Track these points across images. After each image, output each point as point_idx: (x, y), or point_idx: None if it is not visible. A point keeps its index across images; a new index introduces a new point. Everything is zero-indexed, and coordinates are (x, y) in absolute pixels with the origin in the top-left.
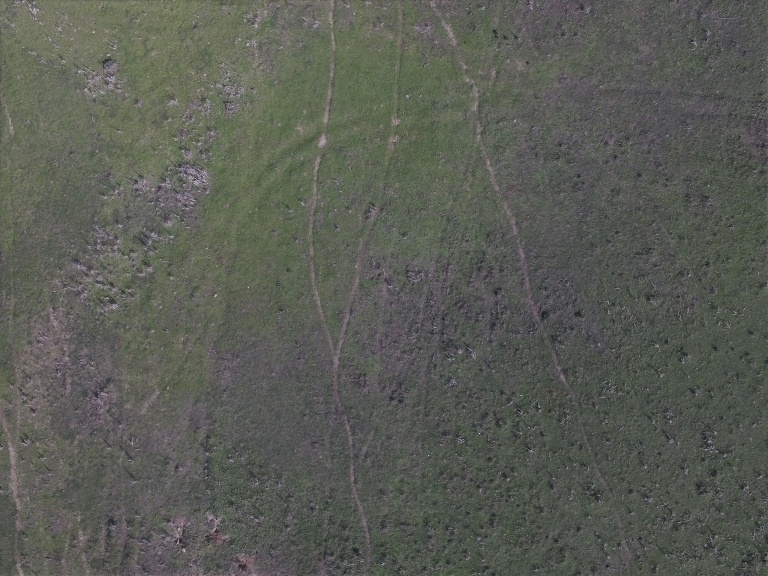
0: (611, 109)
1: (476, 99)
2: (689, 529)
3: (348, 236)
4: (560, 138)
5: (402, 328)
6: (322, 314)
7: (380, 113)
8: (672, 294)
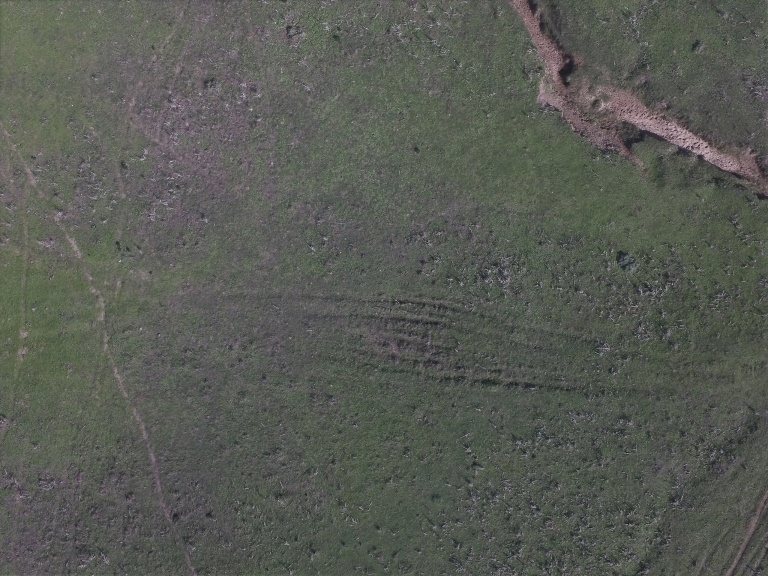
0: (235, 314)
1: (102, 309)
2: None
3: None
4: (186, 344)
5: (36, 536)
6: None
7: (8, 326)
8: (300, 492)
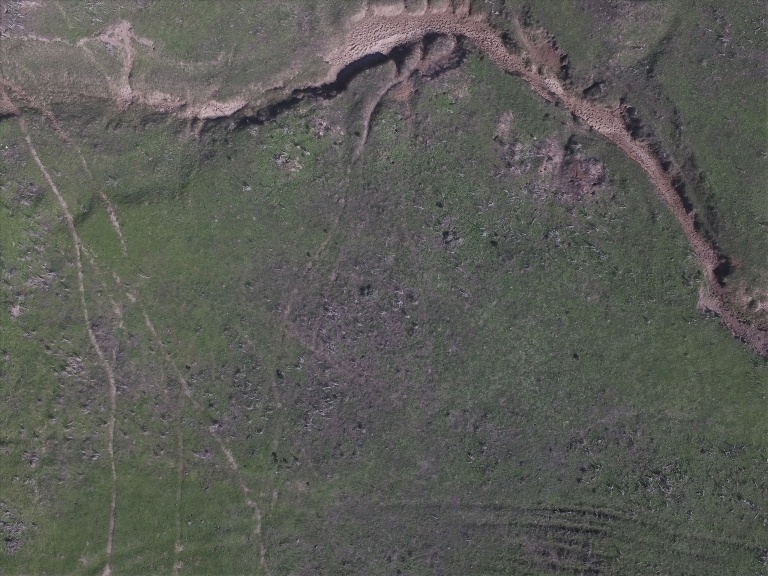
0: (393, 524)
1: (258, 521)
2: None
3: None
4: (343, 556)
5: None
6: None
7: (163, 540)
8: None
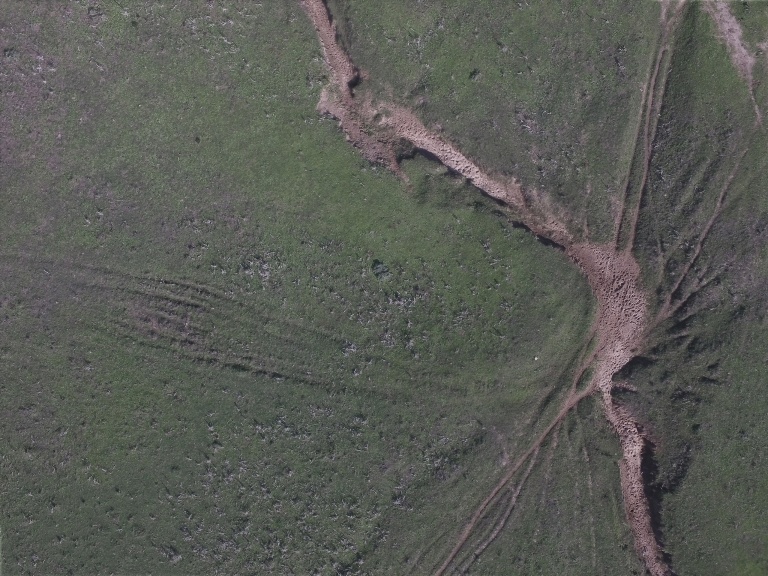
0: (8, 273)
1: None
2: None
3: None
4: None
5: None
6: None
7: None
8: (49, 448)
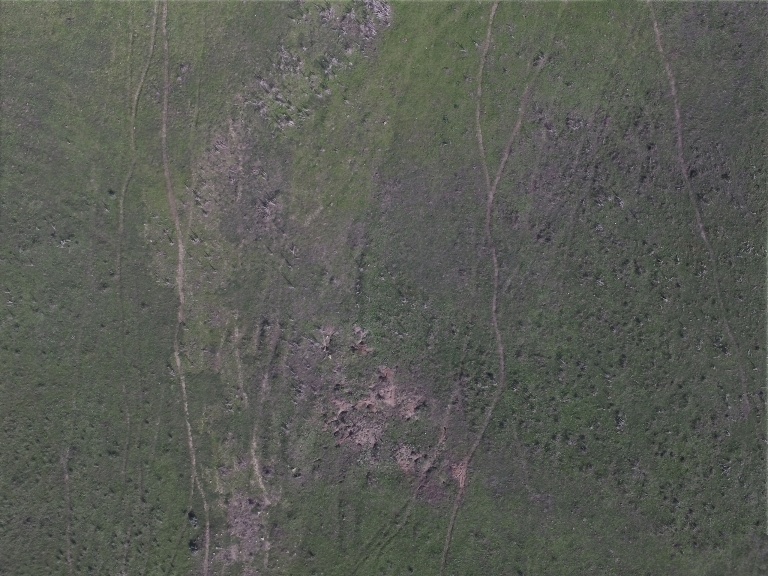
0: None
1: None
2: None
3: (515, 80)
4: (726, 7)
5: (556, 172)
6: (483, 151)
7: None
8: None
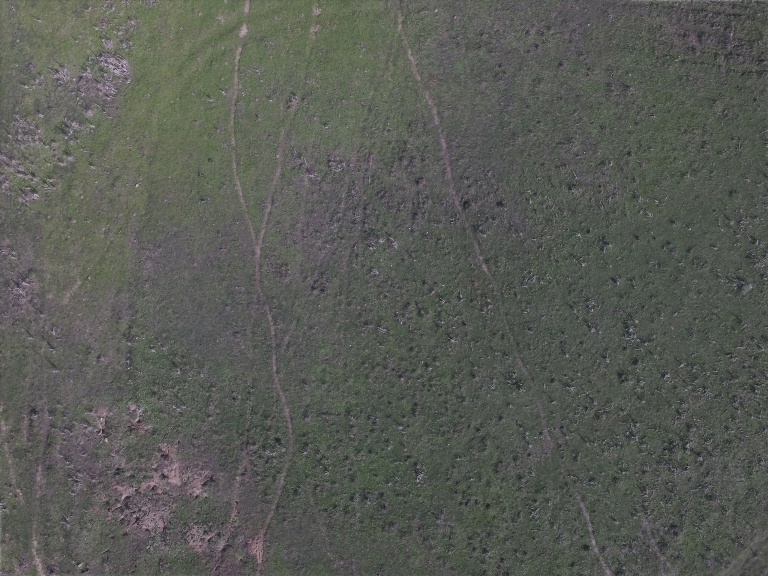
0: None
1: None
2: (611, 418)
3: (269, 126)
4: (481, 28)
5: (324, 218)
6: (244, 204)
7: (301, 2)
8: (594, 184)
